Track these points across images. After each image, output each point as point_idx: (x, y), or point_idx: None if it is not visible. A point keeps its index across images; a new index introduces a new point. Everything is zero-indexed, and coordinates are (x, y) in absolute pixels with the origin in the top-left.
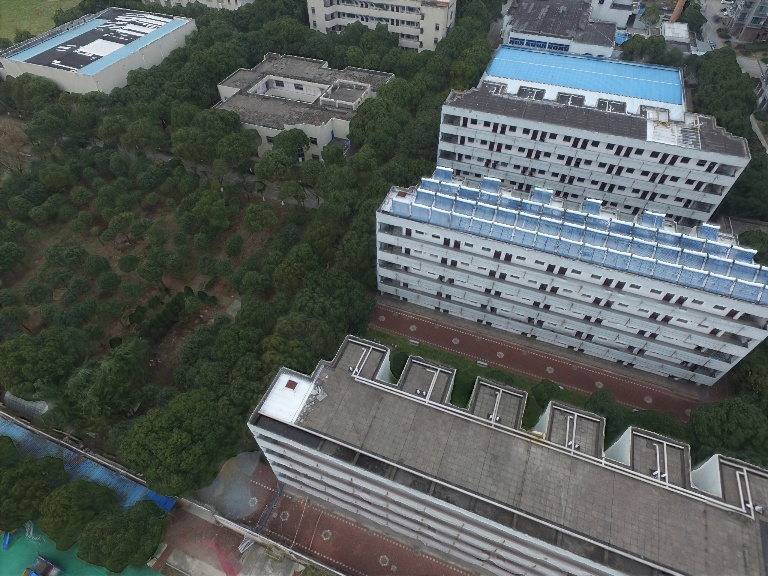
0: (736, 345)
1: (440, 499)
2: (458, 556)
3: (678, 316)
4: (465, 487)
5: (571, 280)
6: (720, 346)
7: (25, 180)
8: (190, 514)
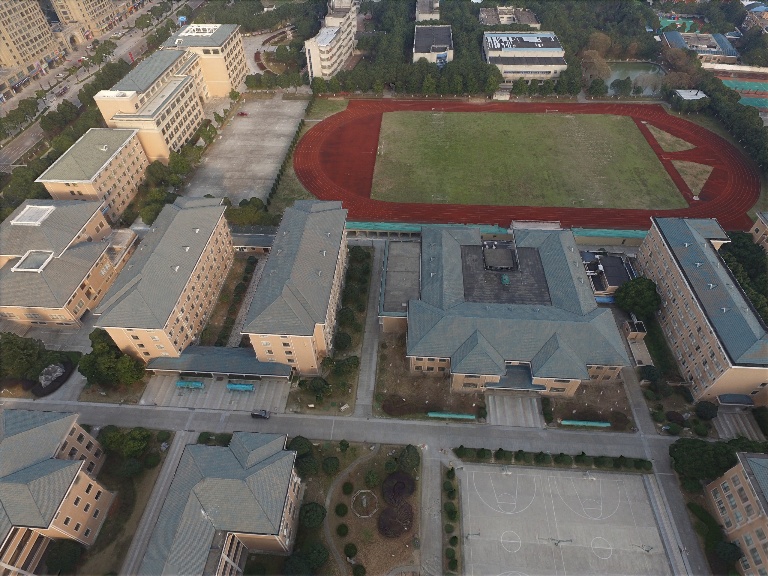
0: None
1: None
2: None
3: None
4: None
5: None
6: None
7: None
8: None
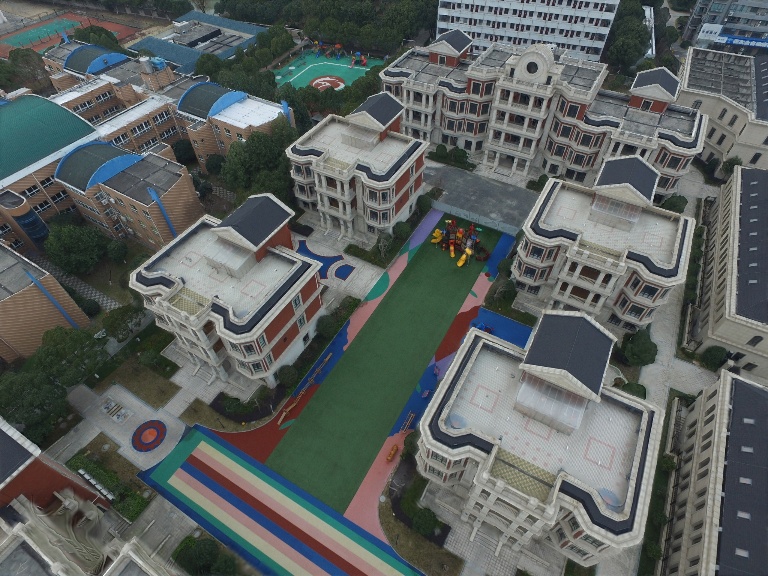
0: None
1: None
2: None
3: None
4: None
5: None
6: None
7: None
8: None
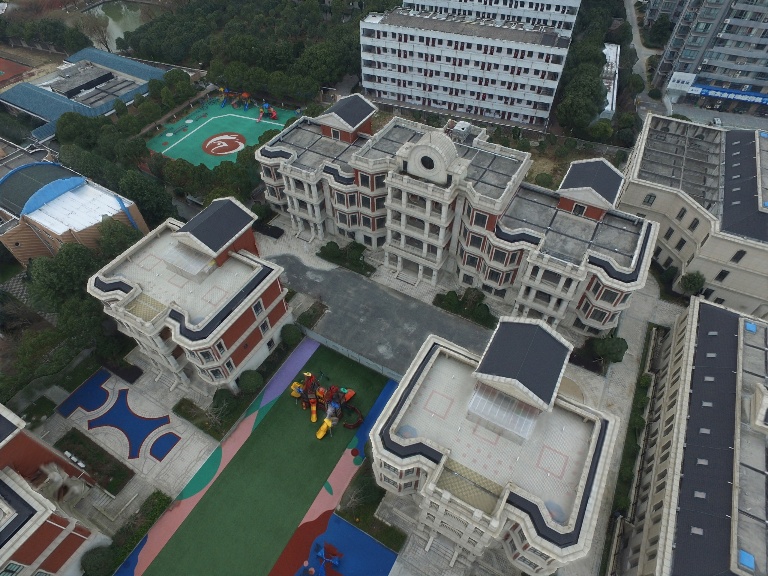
0: (566, 30)
1: (433, 31)
2: (441, 95)
3: (540, 17)
4: (442, 31)
5: (494, 6)
6: (560, 32)
7: (199, 3)
8: (323, 103)
